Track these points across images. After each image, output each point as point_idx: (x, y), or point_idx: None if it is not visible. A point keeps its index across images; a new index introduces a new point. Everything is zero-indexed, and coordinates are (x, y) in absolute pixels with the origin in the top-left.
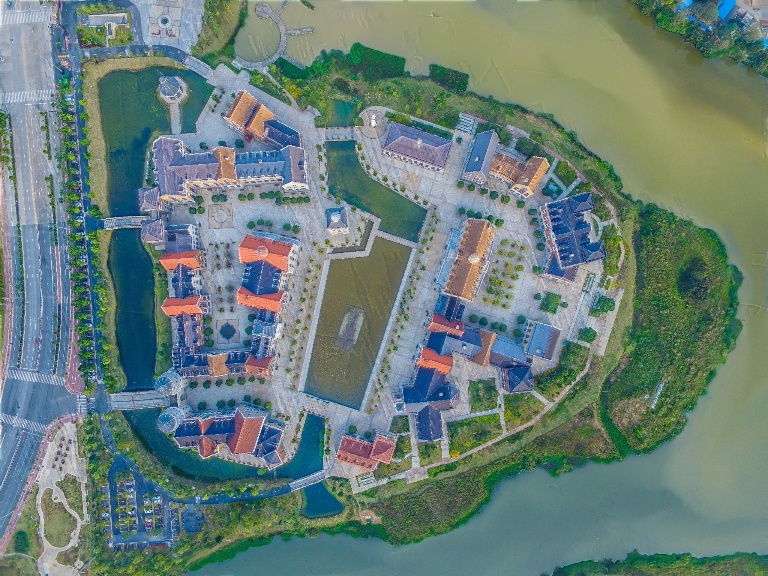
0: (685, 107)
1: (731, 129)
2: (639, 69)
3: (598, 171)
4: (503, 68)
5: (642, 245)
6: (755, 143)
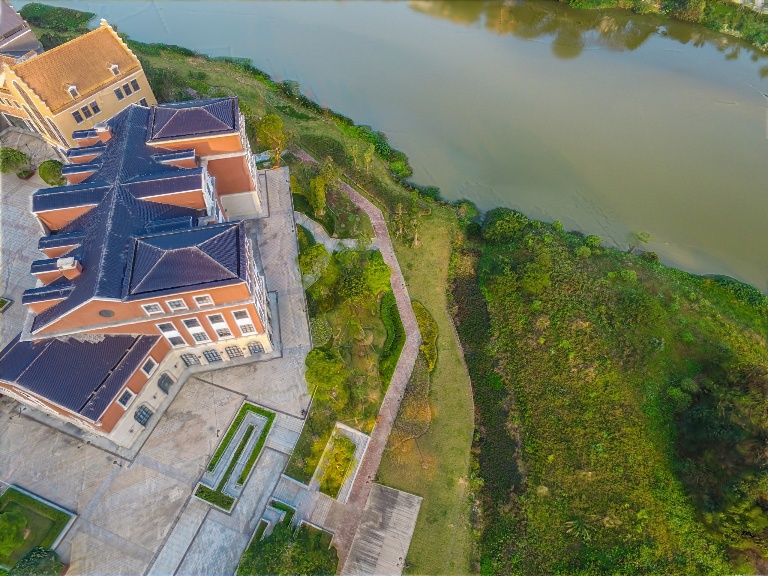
0: (553, 57)
1: (676, 87)
2: (444, 17)
3: (343, 140)
4: (170, 10)
5: (488, 318)
6: (751, 108)
